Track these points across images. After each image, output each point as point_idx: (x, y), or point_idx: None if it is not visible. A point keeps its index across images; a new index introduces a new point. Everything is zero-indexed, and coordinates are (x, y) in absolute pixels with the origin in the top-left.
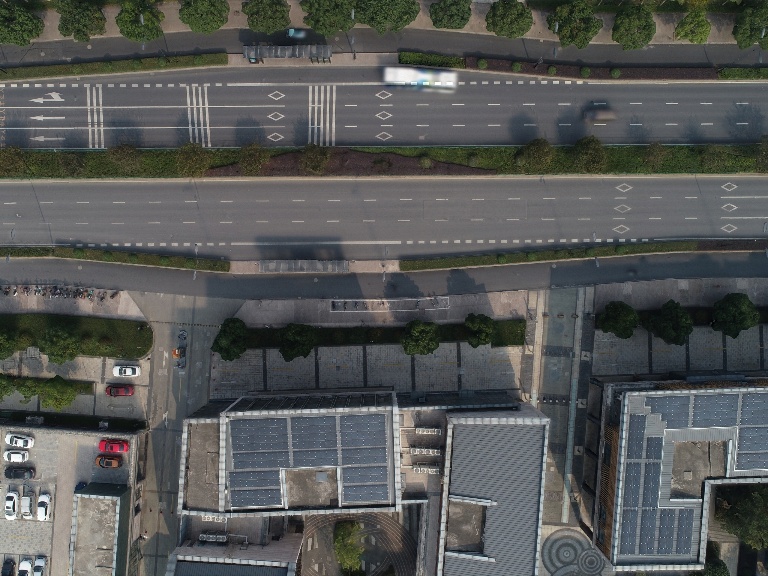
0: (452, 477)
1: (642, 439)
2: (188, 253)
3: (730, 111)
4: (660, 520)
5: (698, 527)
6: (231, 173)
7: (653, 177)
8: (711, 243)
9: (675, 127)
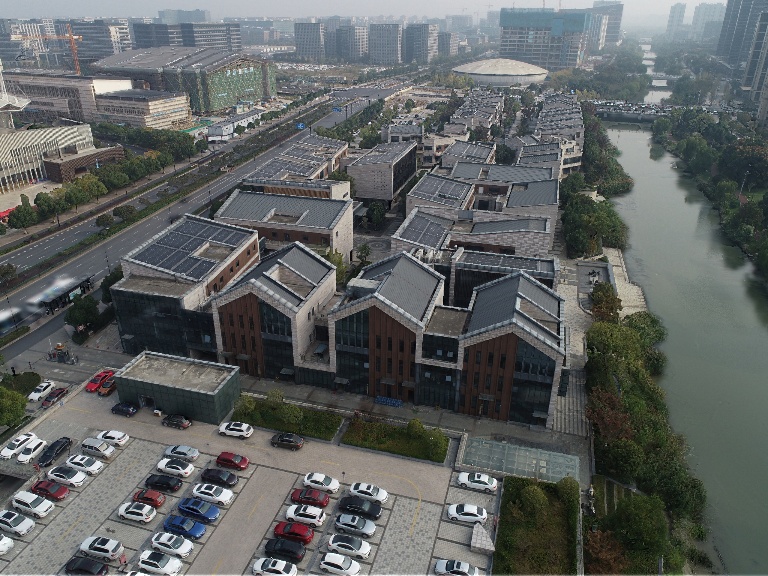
0: None
1: None
2: None
3: (149, 198)
4: None
5: None
6: None
7: (159, 212)
8: (207, 203)
9: None
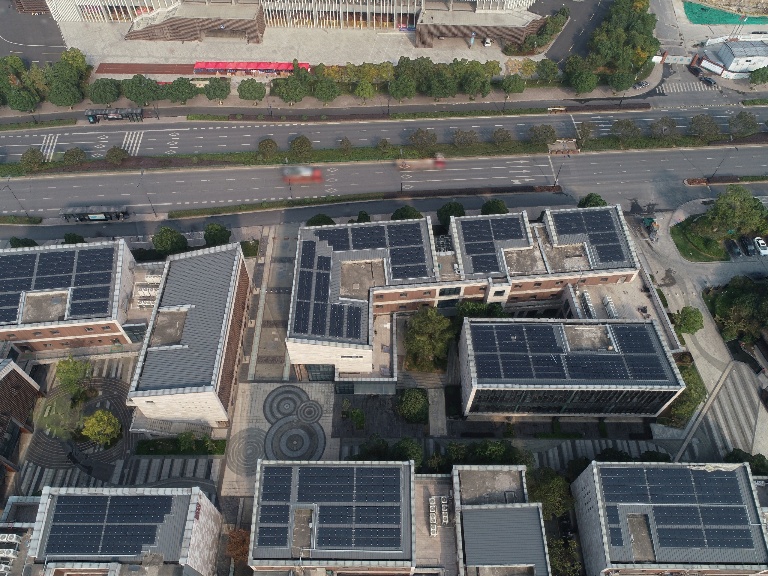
0: (164, 296)
1: (313, 257)
2: None
3: (400, 133)
4: (331, 312)
5: (366, 320)
6: (59, 171)
7: (352, 164)
8: (394, 193)
9: (365, 141)
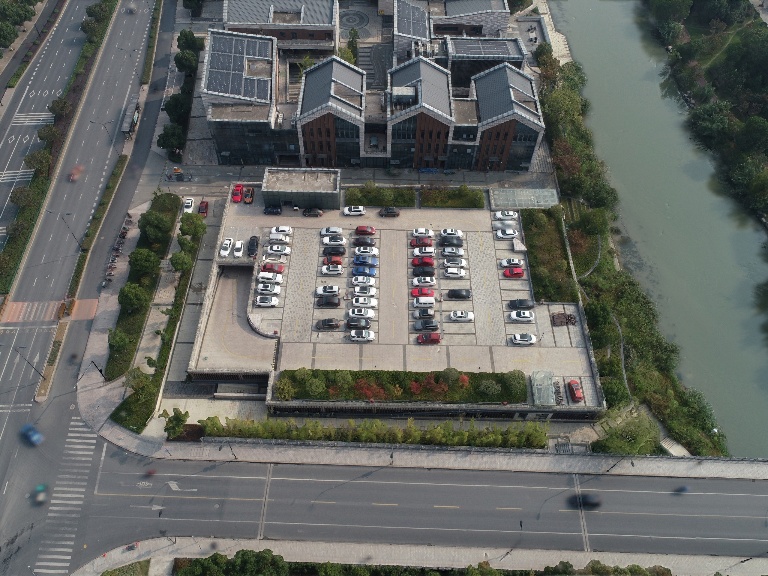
0: None
1: None
2: None
3: None
4: None
5: None
6: (57, 154)
7: (120, 2)
8: None
9: None
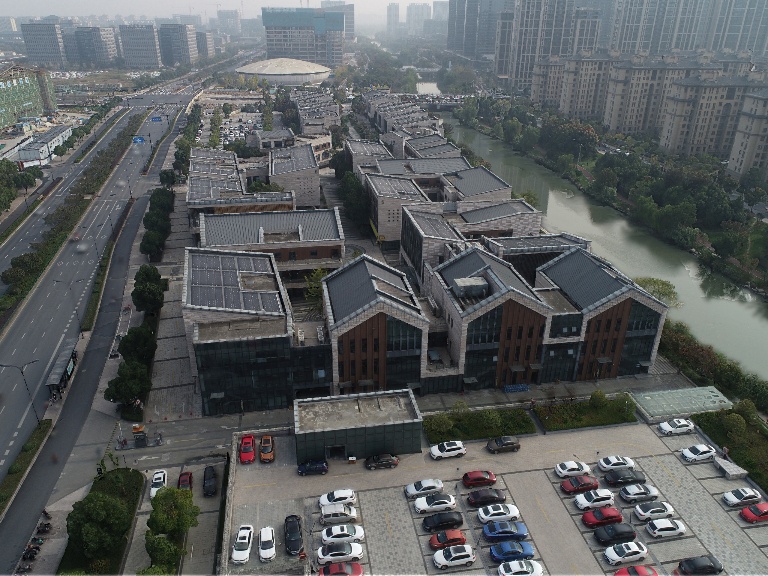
0: None
1: None
2: (15, 459)
3: None
4: None
5: None
6: None
7: None
8: None
9: None
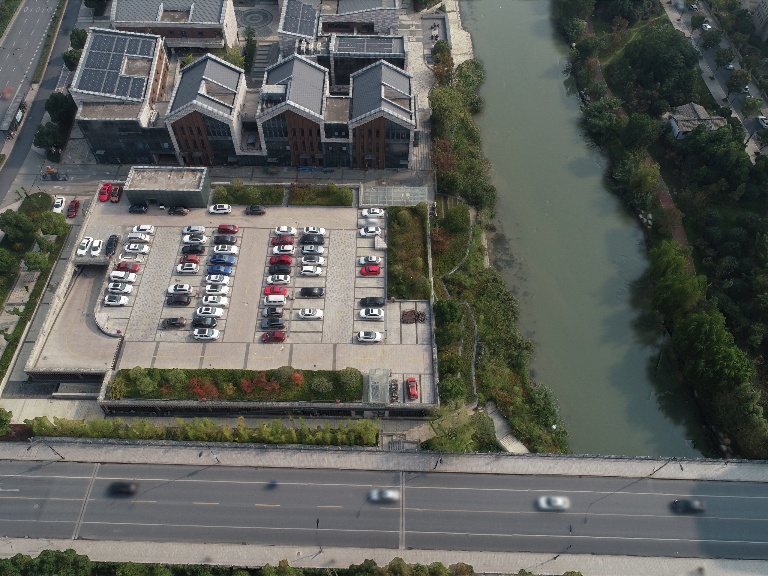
0: None
1: None
2: None
3: None
4: None
5: None
6: None
7: (25, 1)
8: None
9: None
